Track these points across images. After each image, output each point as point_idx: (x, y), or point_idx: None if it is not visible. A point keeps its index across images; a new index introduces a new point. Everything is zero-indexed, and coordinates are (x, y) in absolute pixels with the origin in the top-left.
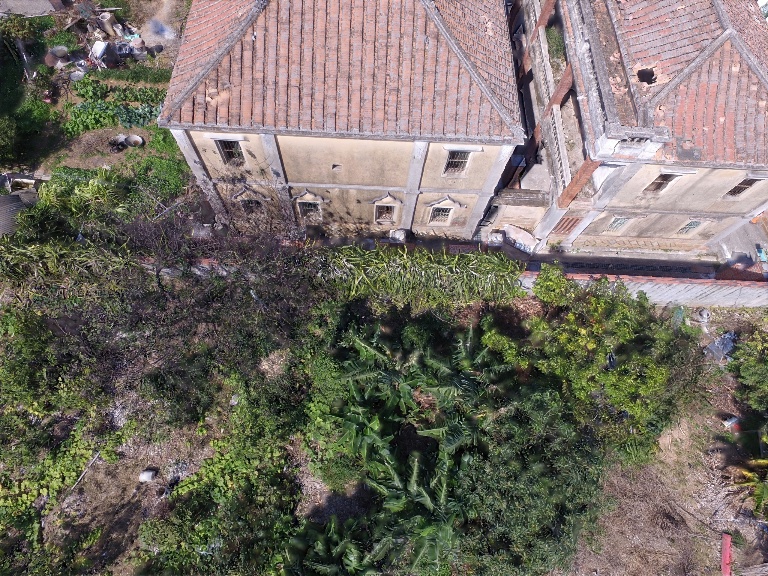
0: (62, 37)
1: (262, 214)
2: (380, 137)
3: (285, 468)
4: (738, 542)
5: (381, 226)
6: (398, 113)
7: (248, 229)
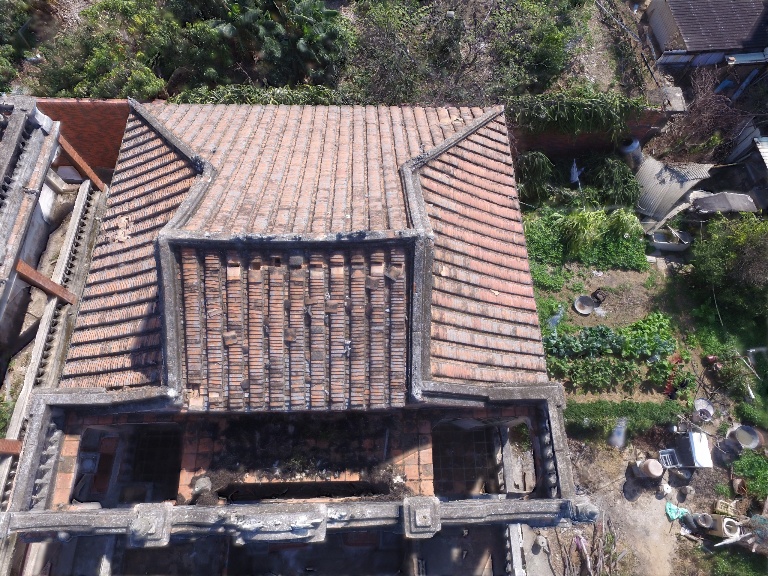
0: (767, 481)
1: None
2: None
3: None
4: None
5: None
6: (262, 116)
7: None
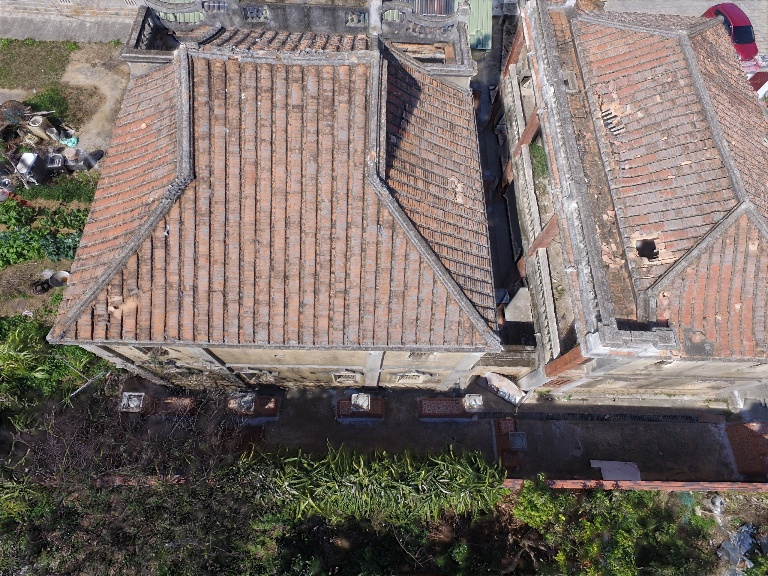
0: None
1: (204, 376)
2: (324, 349)
3: None
4: None
5: (343, 383)
6: (346, 319)
7: (191, 385)
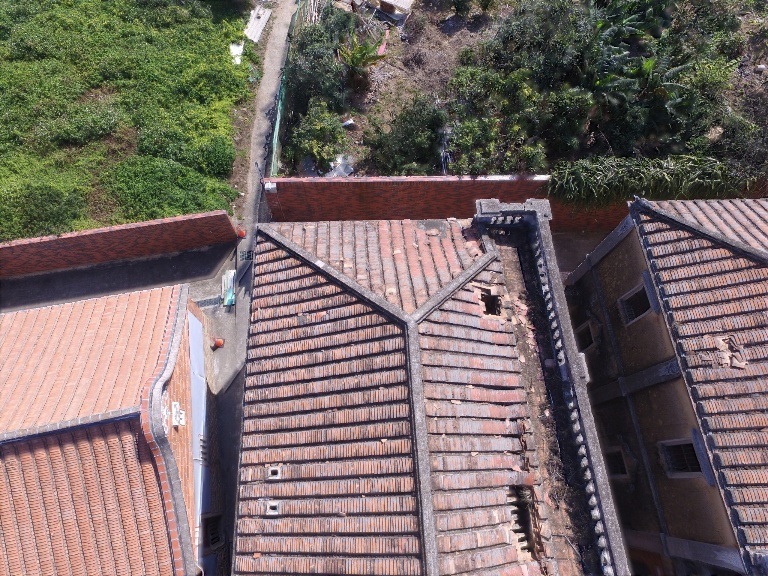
0: None
1: None
2: None
3: None
4: None
5: None
6: None
7: None
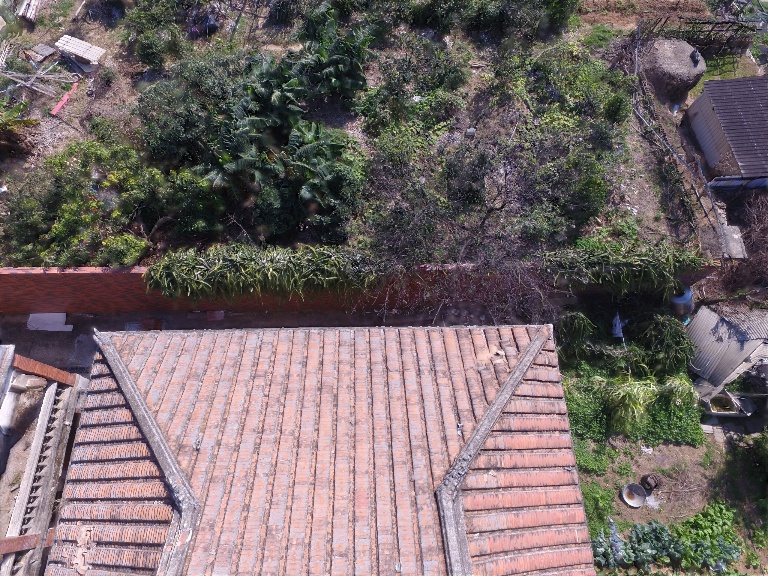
0: None
1: None
2: (284, 329)
3: None
4: None
5: None
6: (258, 354)
7: None
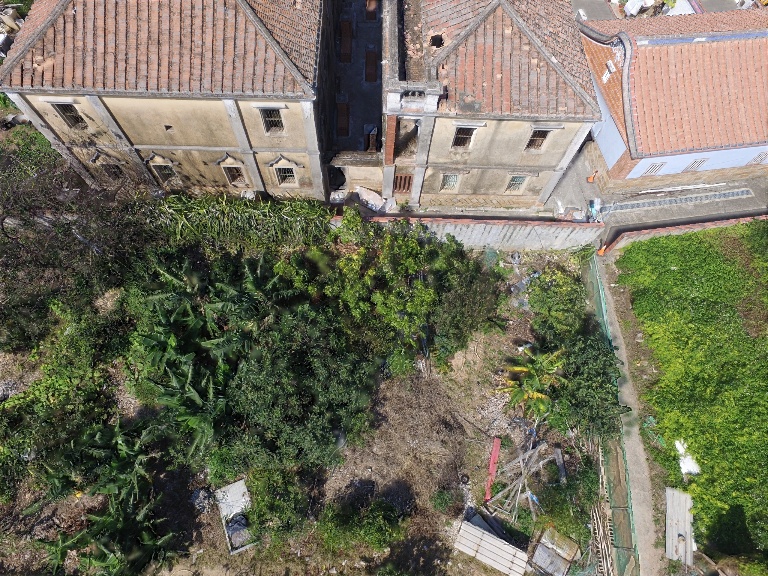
0: None
1: None
2: (187, 95)
3: (105, 387)
4: (507, 444)
5: (238, 189)
6: (203, 74)
7: (121, 195)
